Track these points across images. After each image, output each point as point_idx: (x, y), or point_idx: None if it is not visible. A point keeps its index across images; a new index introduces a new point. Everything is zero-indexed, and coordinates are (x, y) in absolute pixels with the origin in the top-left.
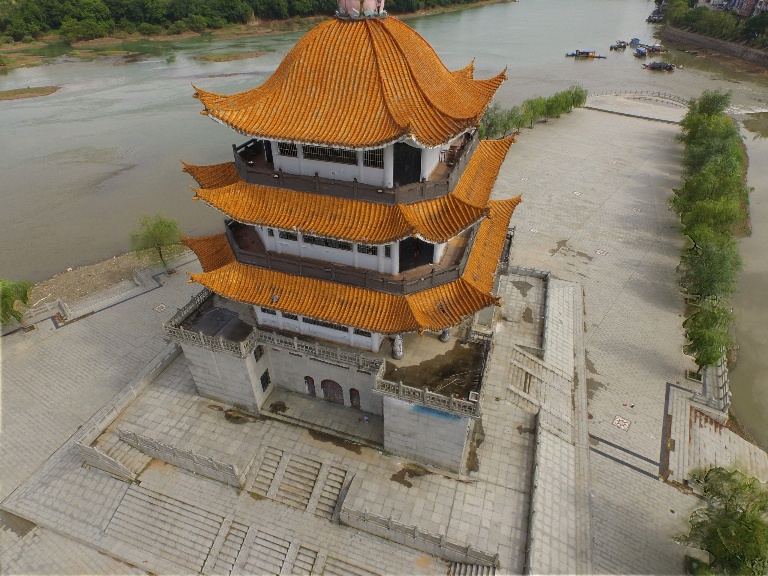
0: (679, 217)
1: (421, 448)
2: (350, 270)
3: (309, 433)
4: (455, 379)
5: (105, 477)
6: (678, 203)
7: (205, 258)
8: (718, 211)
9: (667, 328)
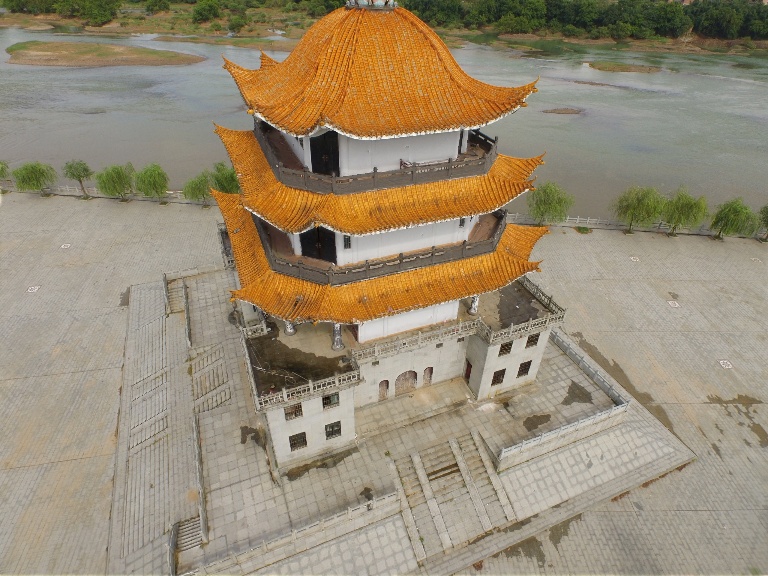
0: None
1: None
2: (280, 234)
3: None
4: (291, 376)
5: (164, 303)
6: None
7: None
8: None
9: None
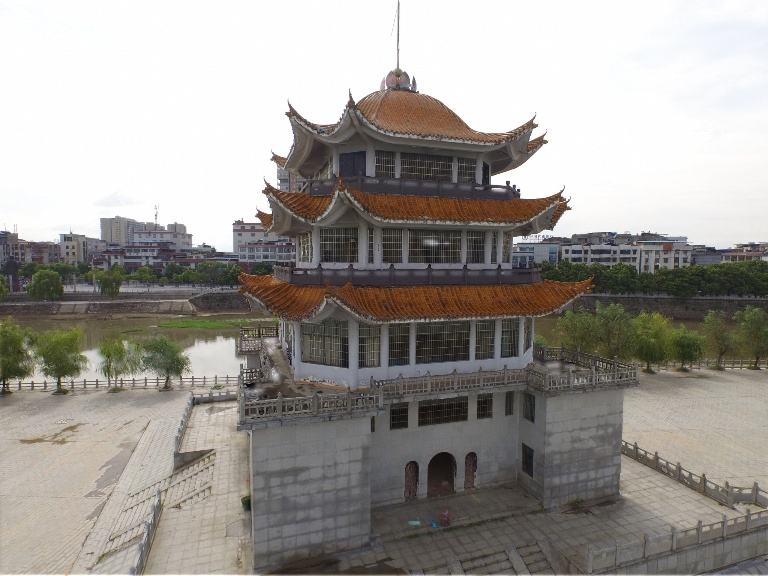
0: None
1: None
2: None
3: None
4: None
5: None
6: (7, 362)
7: None
8: (77, 337)
9: None
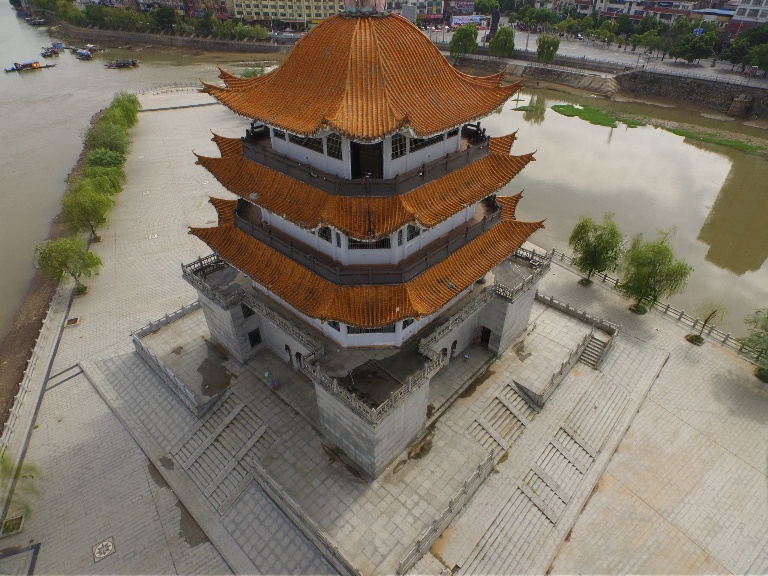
0: None
1: (515, 330)
2: None
3: (463, 398)
4: (515, 265)
5: None
6: None
7: (350, 318)
8: None
9: None
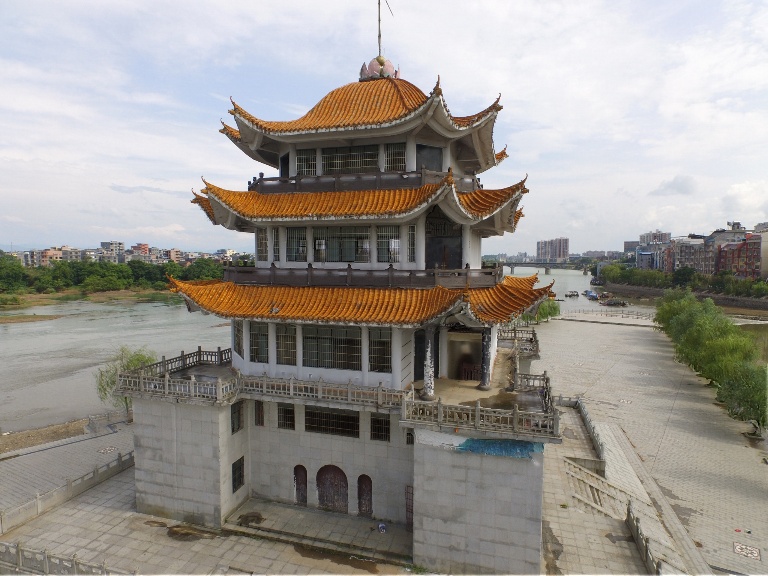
0: (691, 378)
1: (473, 544)
2: None
3: (295, 549)
4: None
5: None
6: (686, 353)
7: None
8: (732, 346)
9: (739, 457)
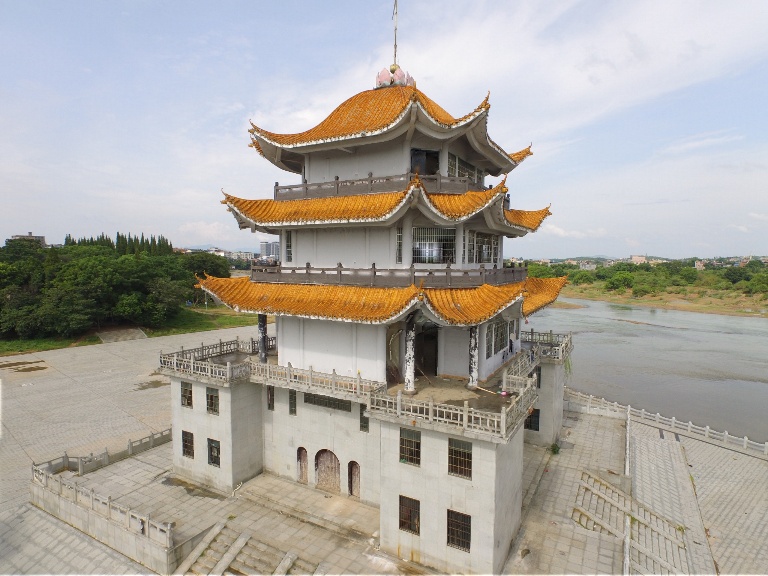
0: None
1: None
2: None
3: None
4: None
5: None
6: None
7: None
8: None
9: None
